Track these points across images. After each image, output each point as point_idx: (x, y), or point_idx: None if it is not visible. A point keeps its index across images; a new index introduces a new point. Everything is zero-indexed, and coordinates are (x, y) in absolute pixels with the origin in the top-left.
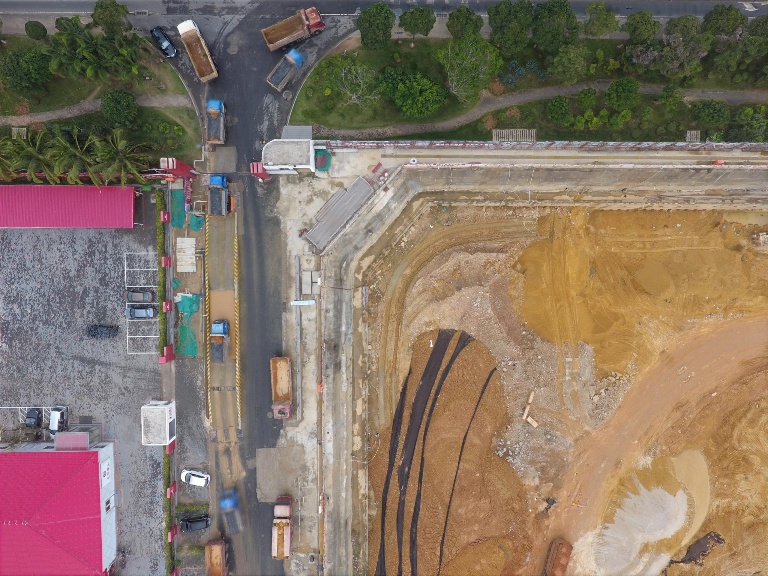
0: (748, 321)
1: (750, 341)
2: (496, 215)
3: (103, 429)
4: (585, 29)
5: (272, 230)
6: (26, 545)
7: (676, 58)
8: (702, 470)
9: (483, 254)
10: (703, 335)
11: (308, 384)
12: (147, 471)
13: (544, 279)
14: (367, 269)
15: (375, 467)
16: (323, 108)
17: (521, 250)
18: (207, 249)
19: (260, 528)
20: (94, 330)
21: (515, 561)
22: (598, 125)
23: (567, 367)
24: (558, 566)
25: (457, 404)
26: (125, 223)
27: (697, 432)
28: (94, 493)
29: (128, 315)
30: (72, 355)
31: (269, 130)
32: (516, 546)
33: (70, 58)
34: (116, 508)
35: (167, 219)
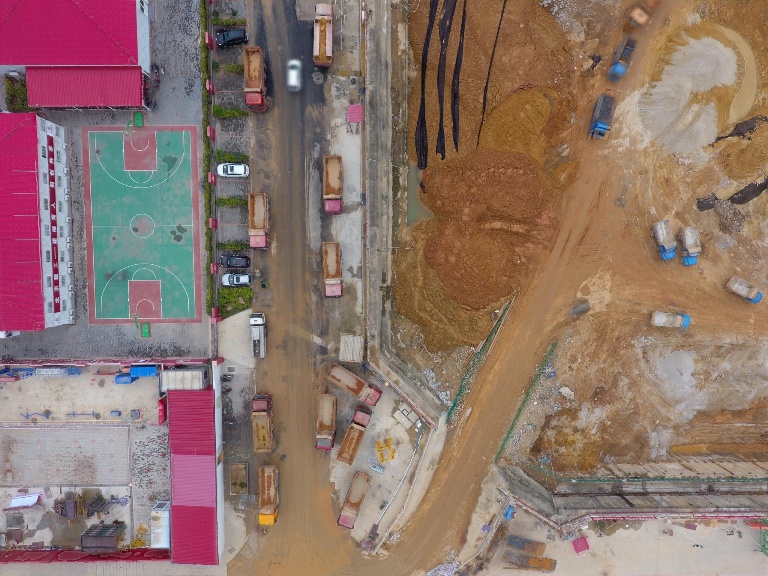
0: None
1: None
2: None
3: None
4: None
5: None
6: (58, 20)
7: None
8: (749, 52)
9: None
10: None
11: None
12: None
13: None
14: None
15: (415, 24)
16: None
17: None
18: None
19: (299, 48)
20: None
21: (560, 114)
22: None
23: None
24: (605, 110)
25: None
26: None
27: (746, 0)
28: None
29: None
30: None
31: None
32: (561, 98)
33: None
34: (149, 22)
35: None
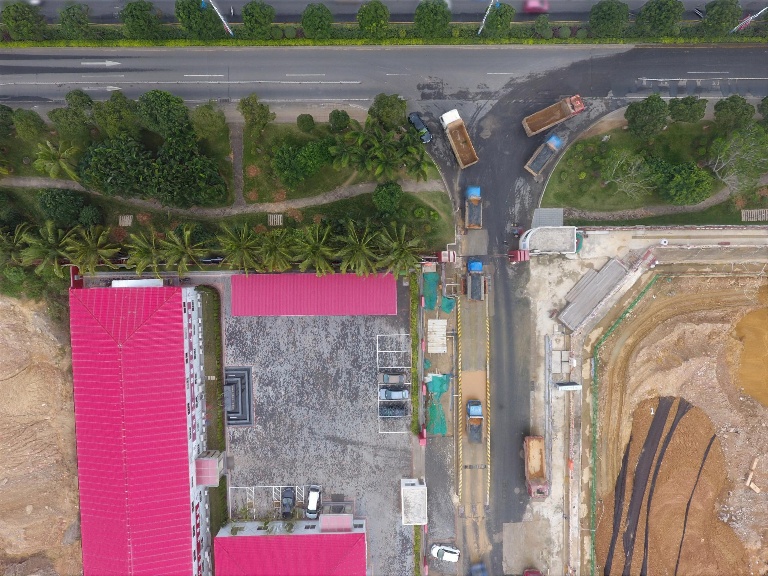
0: None
1: None
2: (719, 285)
3: (354, 506)
4: None
5: (522, 311)
6: None
7: None
8: None
9: (709, 325)
10: None
11: (555, 460)
12: (397, 546)
13: (767, 348)
14: (595, 341)
15: (599, 533)
16: (575, 191)
17: (740, 318)
18: (460, 331)
19: None
20: (346, 411)
21: None
22: None
23: None
24: None
25: (680, 471)
26: (389, 310)
27: None
28: (361, 573)
29: (383, 397)
30: (325, 435)
31: (520, 213)
32: None
33: (360, 157)
34: None
35: None
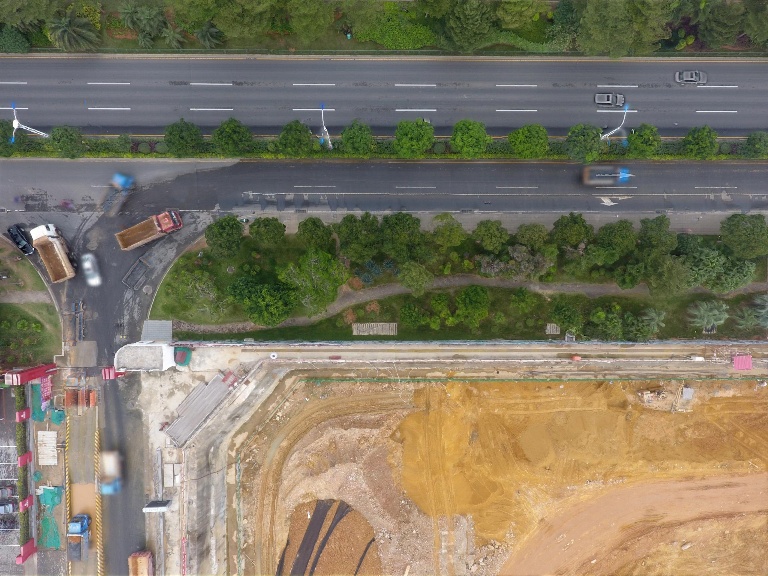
0: (628, 486)
1: (630, 506)
2: (371, 388)
3: None
4: (433, 240)
5: (134, 423)
6: None
7: (522, 271)
8: None
9: (357, 430)
10: (582, 502)
11: (172, 575)
12: None
13: (419, 453)
14: (240, 446)
15: None
16: (183, 304)
17: (398, 420)
18: (67, 444)
19: None
20: None
21: None
22: (455, 323)
23: (443, 540)
24: None
25: None
26: None
27: None
28: None
29: None
30: None
31: (130, 324)
32: None
33: None
34: None
35: (25, 416)
